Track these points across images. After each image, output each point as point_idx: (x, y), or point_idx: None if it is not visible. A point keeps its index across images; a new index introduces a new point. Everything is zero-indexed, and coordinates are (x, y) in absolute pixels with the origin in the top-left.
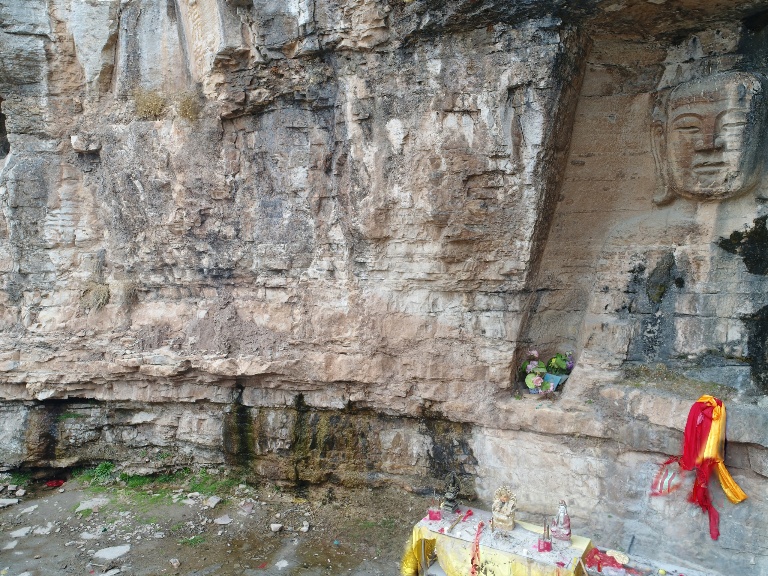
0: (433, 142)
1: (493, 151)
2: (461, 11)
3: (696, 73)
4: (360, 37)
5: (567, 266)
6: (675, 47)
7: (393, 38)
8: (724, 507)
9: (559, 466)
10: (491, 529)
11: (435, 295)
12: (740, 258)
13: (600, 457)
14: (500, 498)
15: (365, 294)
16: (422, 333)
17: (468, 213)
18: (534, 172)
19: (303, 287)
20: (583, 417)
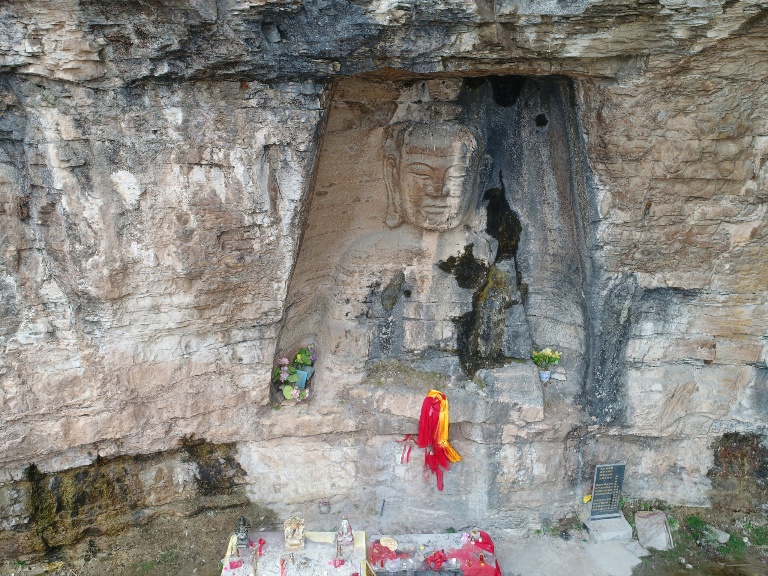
0: (179, 199)
1: (250, 209)
2: (211, 67)
3: (424, 117)
4: (60, 67)
5: (310, 279)
6: (407, 89)
7: (112, 74)
8: (446, 466)
9: (321, 460)
10: (292, 562)
11: (187, 338)
12: (454, 277)
13: (354, 445)
14: (291, 526)
15: (103, 351)
16: (176, 376)
17: (224, 267)
18: (291, 223)
19: (13, 356)
20: (339, 419)
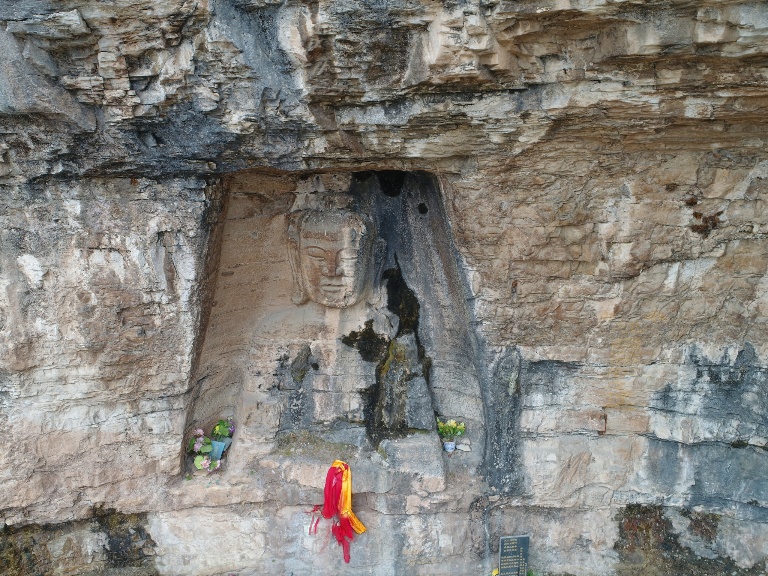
0: (79, 279)
1: (147, 288)
2: (100, 167)
3: (320, 205)
4: None
5: (223, 353)
6: (303, 181)
7: (16, 173)
8: (352, 537)
9: (230, 531)
10: None
11: (96, 408)
12: (356, 351)
13: (263, 516)
14: None
15: (11, 420)
16: (85, 445)
17: (125, 341)
18: (189, 301)
19: None
20: (247, 489)
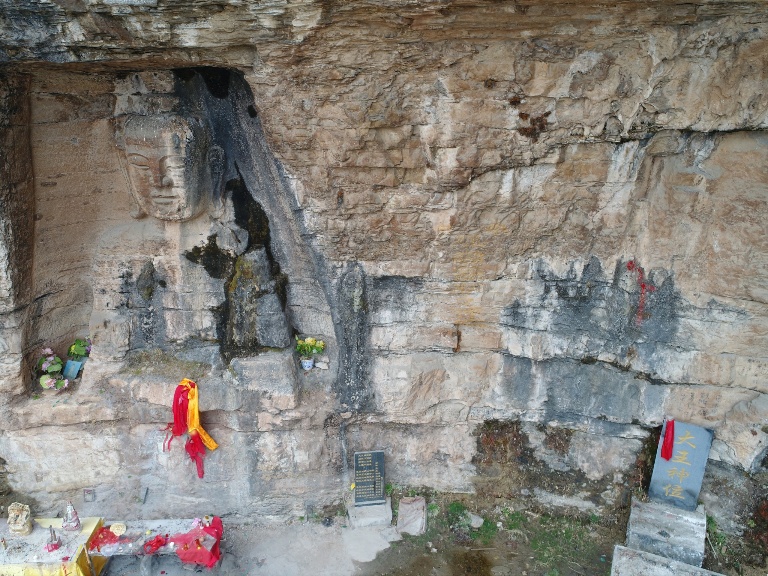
0: None
1: None
2: None
3: (144, 108)
4: None
5: (65, 270)
6: (121, 81)
7: None
8: (206, 454)
9: (82, 449)
10: (4, 546)
11: None
12: (202, 267)
13: (116, 434)
14: (14, 512)
15: None
16: None
17: None
18: None
19: None
20: (95, 407)
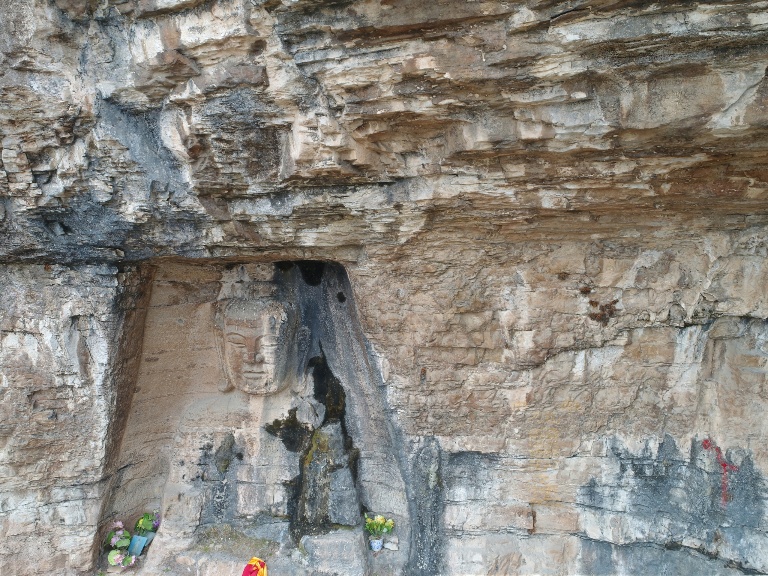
0: None
1: (58, 371)
2: (13, 253)
3: (245, 294)
4: None
5: (149, 441)
6: (228, 271)
7: None
8: None
9: None
10: None
11: (5, 495)
12: (280, 440)
13: None
14: None
15: None
16: None
17: (35, 425)
18: (103, 385)
19: None
20: None
